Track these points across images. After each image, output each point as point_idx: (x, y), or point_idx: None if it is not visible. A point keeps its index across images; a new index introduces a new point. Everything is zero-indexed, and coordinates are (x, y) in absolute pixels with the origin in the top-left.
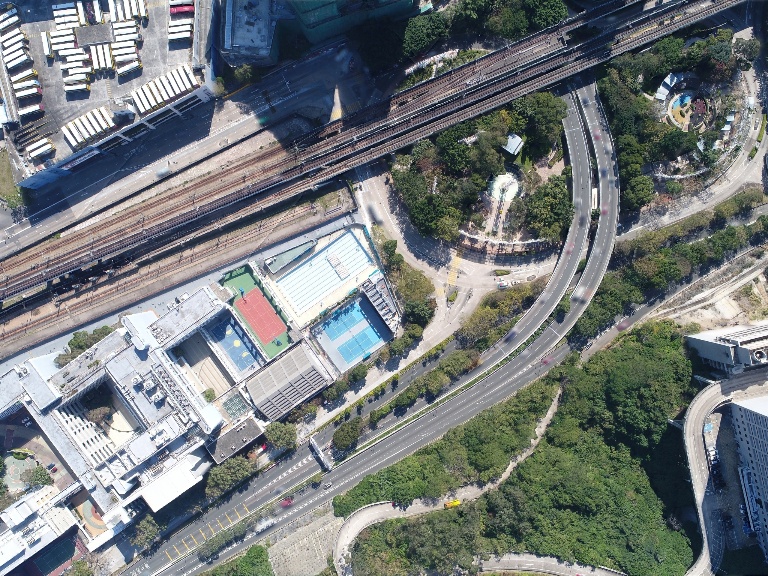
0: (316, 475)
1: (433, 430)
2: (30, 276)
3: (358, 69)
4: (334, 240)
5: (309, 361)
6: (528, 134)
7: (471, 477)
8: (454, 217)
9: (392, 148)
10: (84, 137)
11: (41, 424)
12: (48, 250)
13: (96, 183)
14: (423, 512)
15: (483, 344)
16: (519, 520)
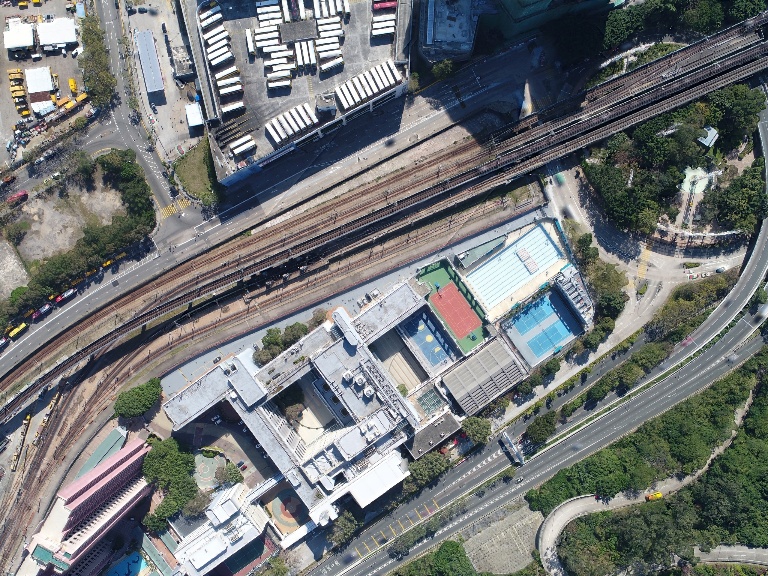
0: (510, 469)
1: (625, 423)
2: (221, 273)
3: (548, 63)
4: (524, 234)
5: (509, 355)
6: (720, 126)
7: (674, 469)
8: (653, 210)
9: (587, 142)
10: (288, 133)
11: (246, 421)
12: (239, 247)
13: (286, 180)
14: (625, 505)
15: (677, 336)
16: (731, 511)
